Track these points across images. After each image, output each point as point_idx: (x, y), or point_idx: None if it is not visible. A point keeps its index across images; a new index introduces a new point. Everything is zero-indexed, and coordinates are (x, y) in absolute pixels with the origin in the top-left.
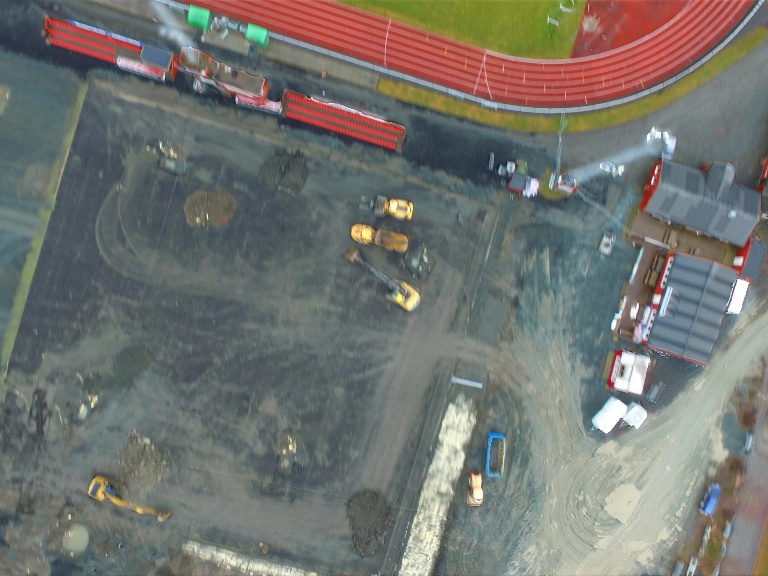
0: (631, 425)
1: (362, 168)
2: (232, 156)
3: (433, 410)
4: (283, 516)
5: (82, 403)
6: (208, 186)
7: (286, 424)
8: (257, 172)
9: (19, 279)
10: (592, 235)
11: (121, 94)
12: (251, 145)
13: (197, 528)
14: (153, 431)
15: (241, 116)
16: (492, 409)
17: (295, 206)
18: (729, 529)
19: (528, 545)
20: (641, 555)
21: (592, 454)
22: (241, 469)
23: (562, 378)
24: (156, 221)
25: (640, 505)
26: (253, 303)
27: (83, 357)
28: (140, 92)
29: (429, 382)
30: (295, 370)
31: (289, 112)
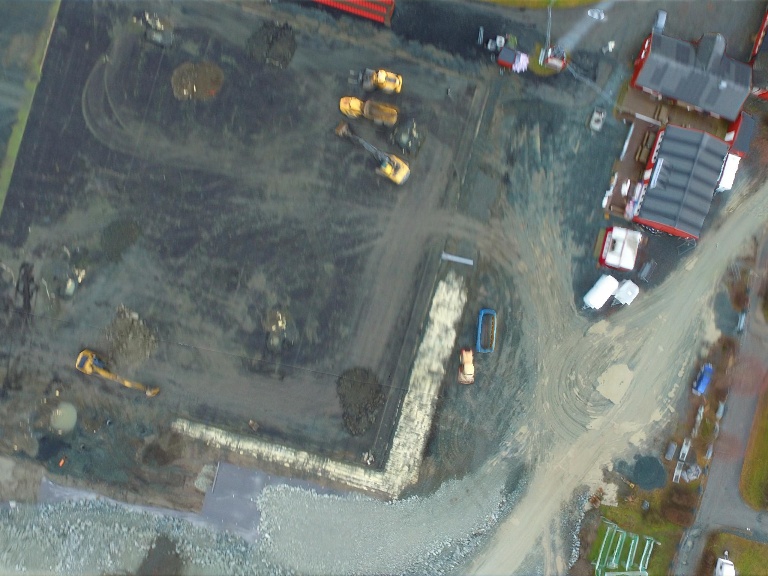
0: (623, 303)
1: (351, 42)
2: (219, 28)
3: (423, 287)
4: (273, 393)
5: (69, 278)
6: (195, 59)
7: (275, 300)
8: (245, 45)
9: (5, 151)
10: (582, 112)
11: None
12: (238, 17)
13: (186, 405)
14: (141, 306)
15: None
16: (483, 286)
17: (283, 79)
18: (722, 409)
19: (520, 425)
20: (634, 436)
21: (584, 333)
22: (230, 346)
23: (553, 256)
24: (143, 94)
25: (632, 385)
26: (241, 177)
27: (70, 231)
28: None
29: (419, 258)
30: (284, 245)
31: None
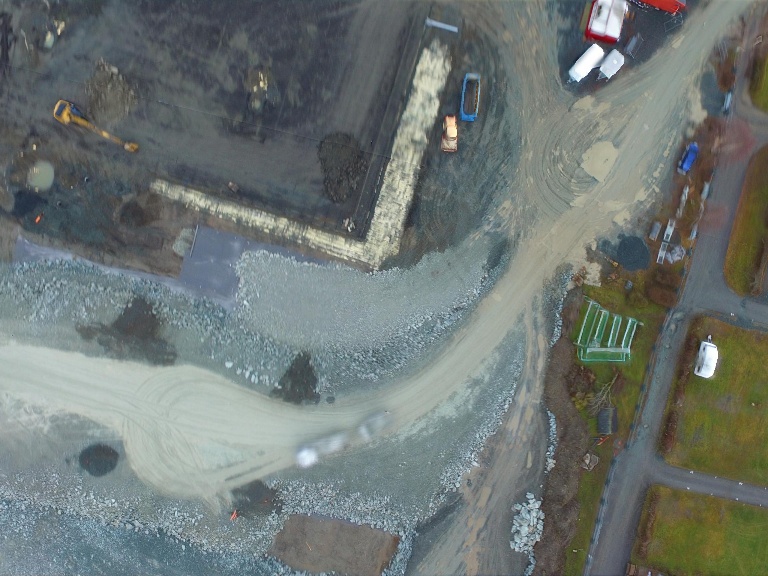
0: (608, 77)
1: None
2: None
3: (407, 53)
4: (253, 156)
5: (48, 30)
6: None
7: (257, 60)
8: None
9: None
10: None
11: None
12: None
13: (165, 165)
14: (121, 62)
15: None
16: (467, 55)
17: None
18: (707, 188)
19: (503, 200)
20: (618, 215)
21: (569, 108)
22: (211, 105)
23: (539, 28)
24: None
25: (617, 164)
26: None
27: None
28: None
29: (403, 23)
30: (267, 5)
31: None
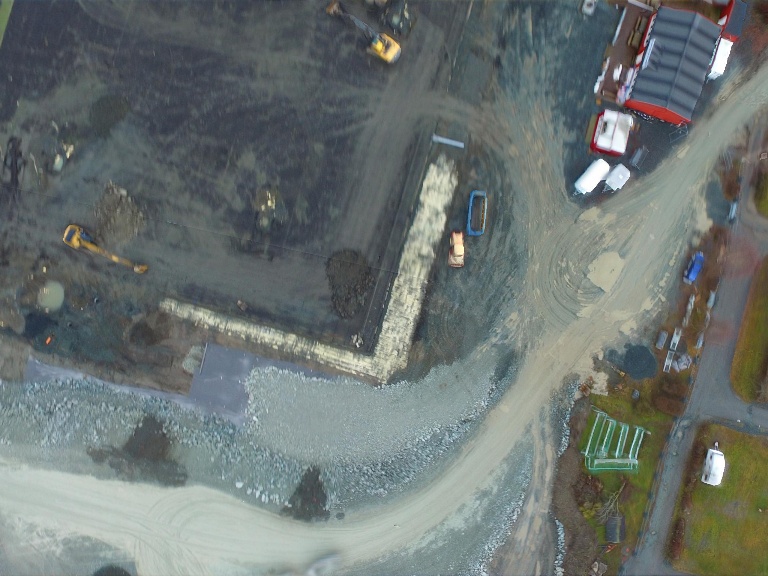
0: (614, 189)
1: None
2: None
3: (414, 169)
4: (262, 274)
5: (57, 153)
6: None
7: (265, 179)
8: None
9: None
10: None
11: None
12: None
13: (174, 284)
14: (130, 183)
15: None
16: (474, 170)
17: None
18: (713, 297)
19: (510, 312)
20: (624, 325)
21: (575, 220)
22: (219, 225)
23: (544, 141)
24: None
25: (623, 274)
26: (231, 55)
27: (59, 105)
28: None
29: (410, 140)
30: (274, 124)
31: None
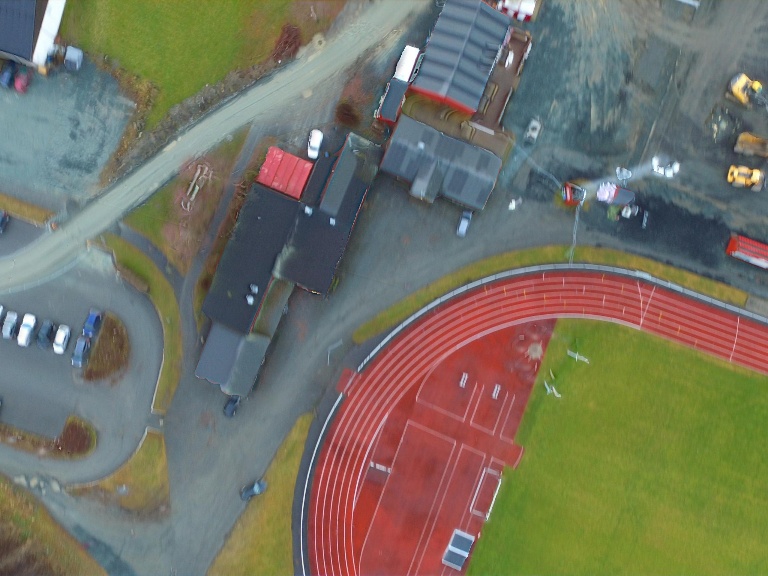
0: None
1: None
2: None
3: None
4: None
5: None
6: None
7: None
8: None
9: None
10: (546, 141)
11: None
12: None
13: None
14: None
15: None
16: None
17: None
18: None
19: None
20: None
21: None
22: None
23: None
24: None
25: None
26: None
27: None
28: None
29: (721, 4)
30: None
31: None
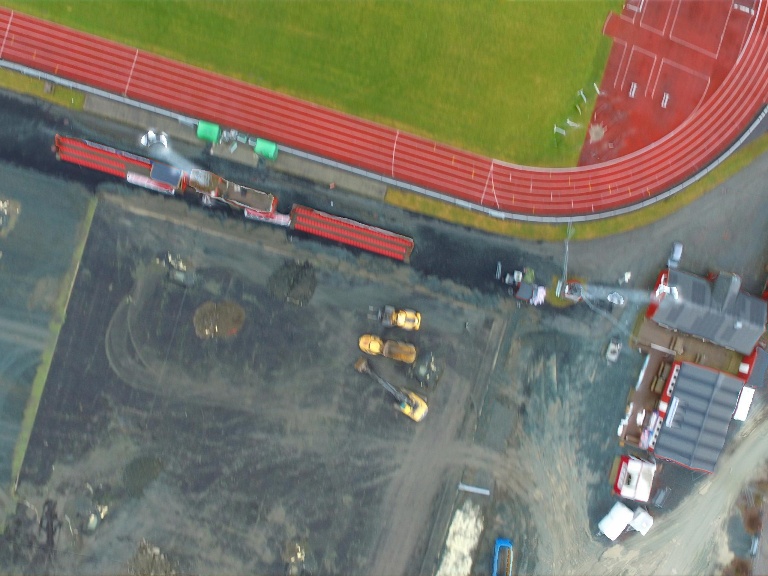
0: (637, 530)
1: (370, 278)
2: (241, 268)
3: (440, 517)
4: None
5: (92, 513)
6: (217, 298)
7: (294, 532)
8: (266, 283)
9: (29, 392)
10: (599, 342)
11: (131, 207)
12: (260, 256)
13: None
14: (162, 540)
15: (250, 228)
16: (499, 515)
17: (303, 317)
18: None
19: None
20: None
21: (598, 558)
22: None
23: (569, 483)
24: (165, 333)
25: None
26: (262, 413)
27: (93, 468)
28: (150, 205)
29: (437, 489)
30: (303, 479)
31: (298, 224)
